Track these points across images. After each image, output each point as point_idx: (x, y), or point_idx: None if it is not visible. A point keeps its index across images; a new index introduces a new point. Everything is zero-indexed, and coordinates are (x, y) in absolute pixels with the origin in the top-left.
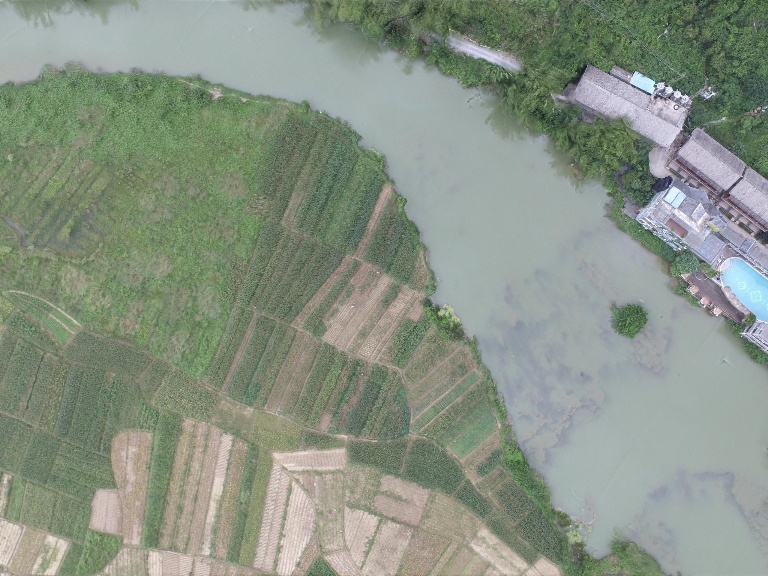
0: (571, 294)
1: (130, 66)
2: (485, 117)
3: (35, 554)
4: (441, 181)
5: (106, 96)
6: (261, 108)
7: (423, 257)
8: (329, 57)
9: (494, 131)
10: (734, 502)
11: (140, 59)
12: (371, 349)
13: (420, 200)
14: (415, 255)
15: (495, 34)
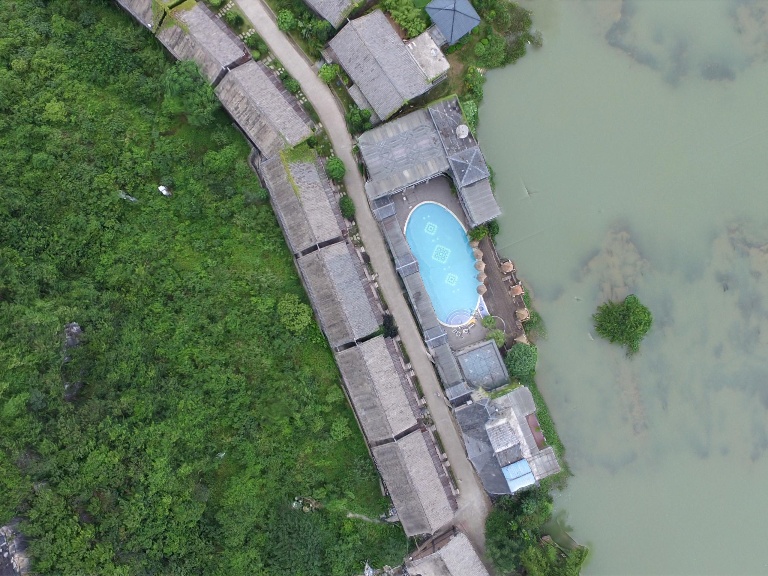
0: (676, 400)
1: None
2: None
3: None
4: None
5: None
6: None
7: None
8: None
9: None
10: (627, 3)
11: None
12: None
13: None
14: None
15: None
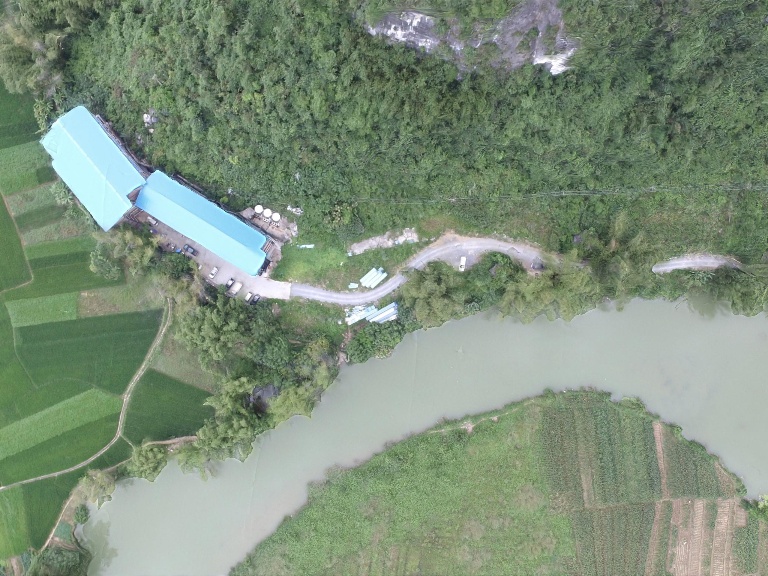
0: None
1: (381, 444)
2: (685, 305)
3: None
4: (695, 391)
5: (377, 483)
6: (514, 418)
7: (720, 467)
8: (533, 332)
9: (701, 314)
10: None
11: (385, 432)
12: (720, 571)
13: (688, 418)
14: (712, 469)
15: (681, 247)
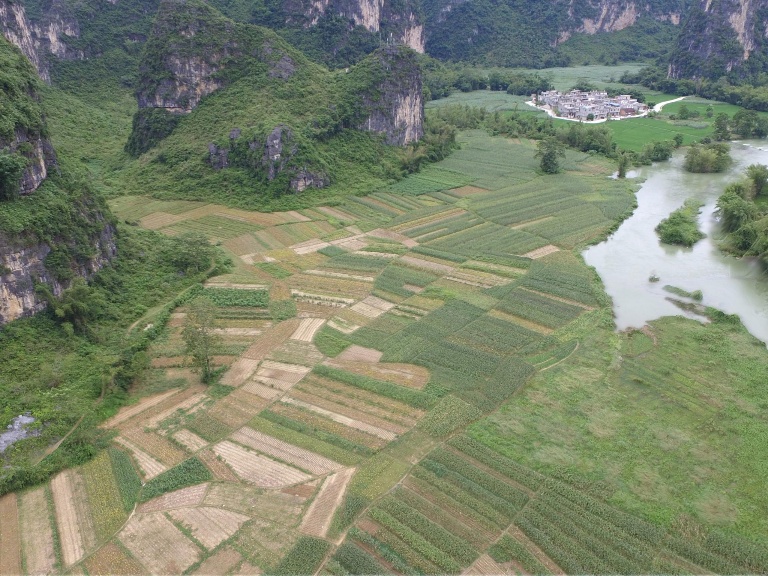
0: None
1: None
2: None
3: (350, 320)
4: None
5: None
6: None
7: None
8: None
9: None
10: None
11: None
12: None
13: None
14: None
15: None
